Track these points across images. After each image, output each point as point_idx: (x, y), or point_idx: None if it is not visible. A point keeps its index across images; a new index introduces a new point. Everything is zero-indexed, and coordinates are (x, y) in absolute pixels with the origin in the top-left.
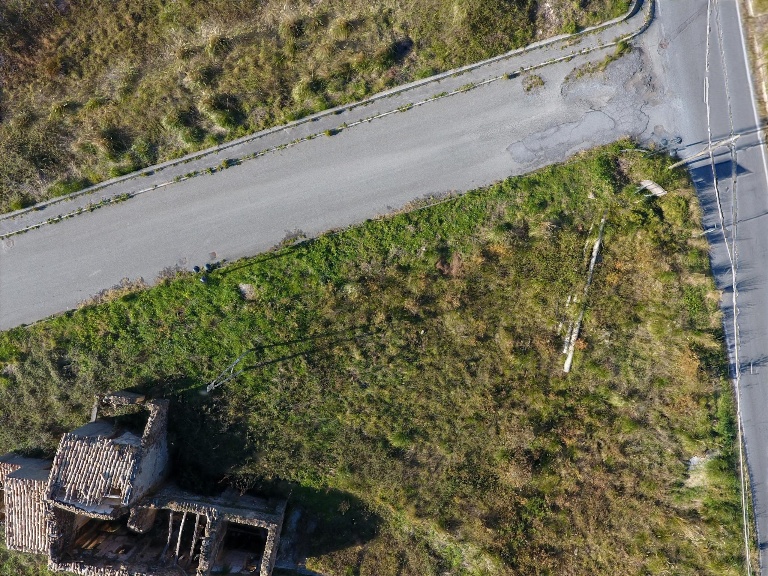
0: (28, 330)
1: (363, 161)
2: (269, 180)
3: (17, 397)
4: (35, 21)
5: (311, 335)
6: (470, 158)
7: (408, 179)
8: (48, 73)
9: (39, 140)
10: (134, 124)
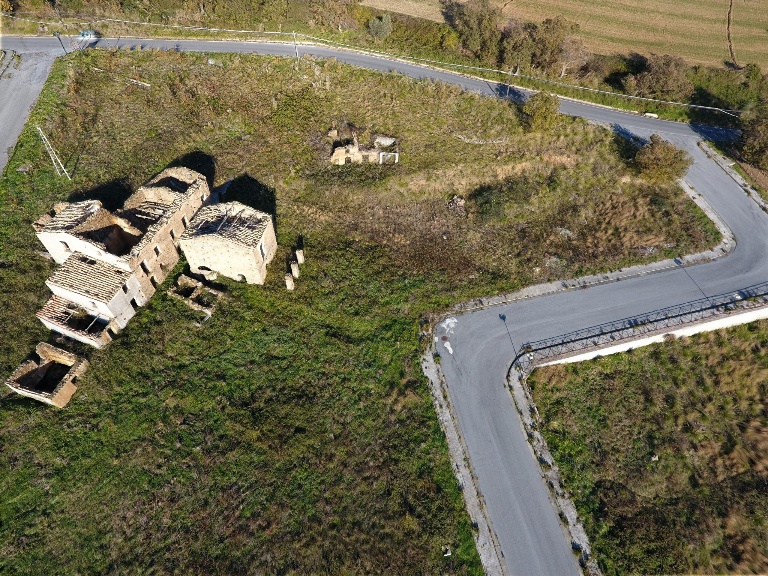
0: None
1: None
2: None
3: (3, 305)
4: None
5: None
6: (24, 94)
7: (16, 111)
8: None
9: None
10: None
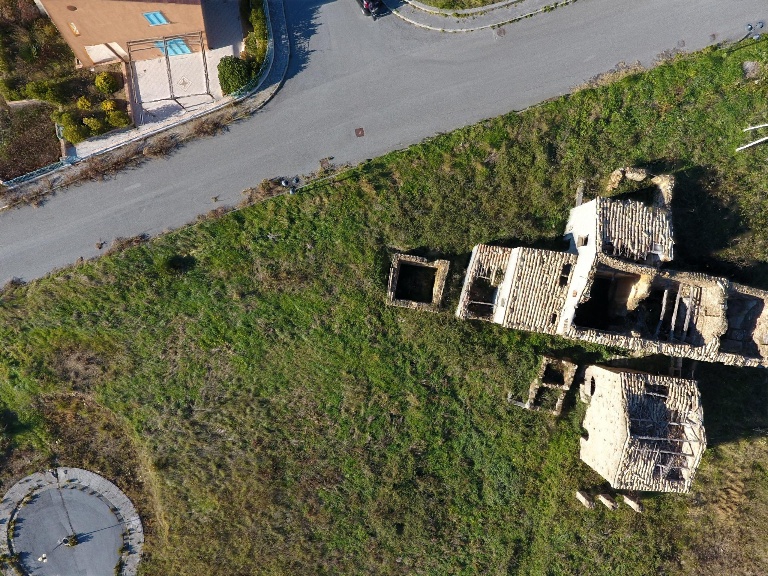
0: (520, 115)
1: None
2: None
3: (494, 187)
4: None
5: None
6: None
7: None
8: None
9: None
10: None
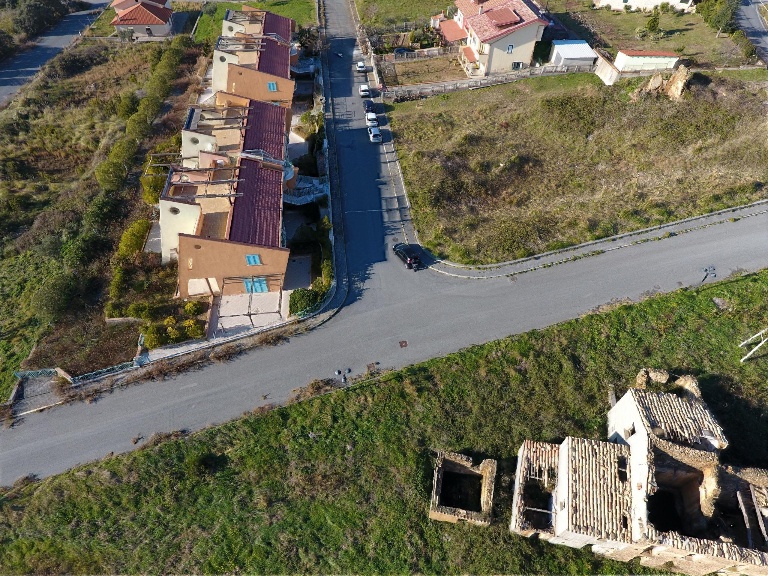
0: (541, 332)
1: (764, 233)
2: (702, 243)
3: (529, 391)
4: (497, 184)
5: None
6: None
7: None
8: (509, 205)
9: (536, 222)
10: (595, 217)
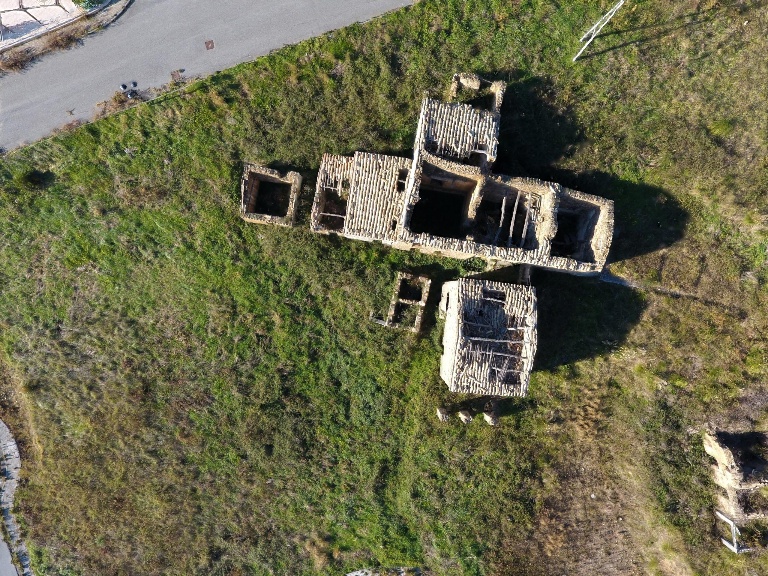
0: (364, 26)
1: None
2: None
3: (342, 99)
4: None
5: (642, 24)
6: None
7: None
8: None
9: None
10: None
